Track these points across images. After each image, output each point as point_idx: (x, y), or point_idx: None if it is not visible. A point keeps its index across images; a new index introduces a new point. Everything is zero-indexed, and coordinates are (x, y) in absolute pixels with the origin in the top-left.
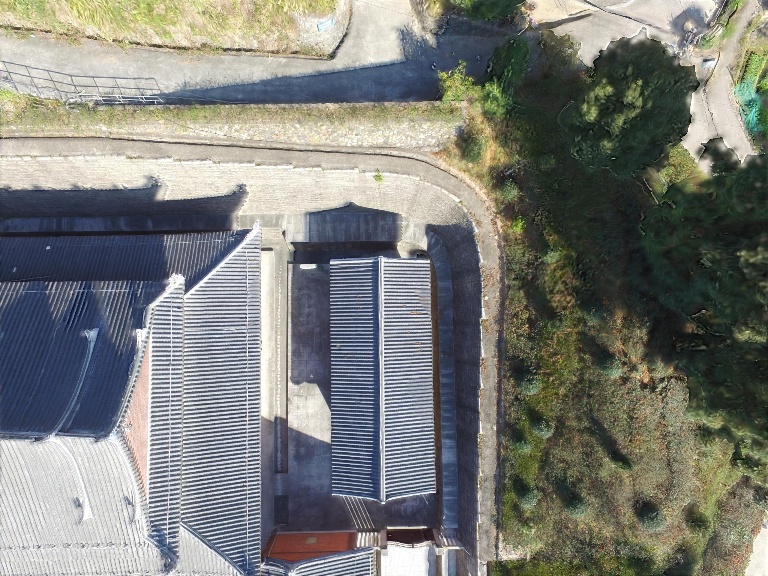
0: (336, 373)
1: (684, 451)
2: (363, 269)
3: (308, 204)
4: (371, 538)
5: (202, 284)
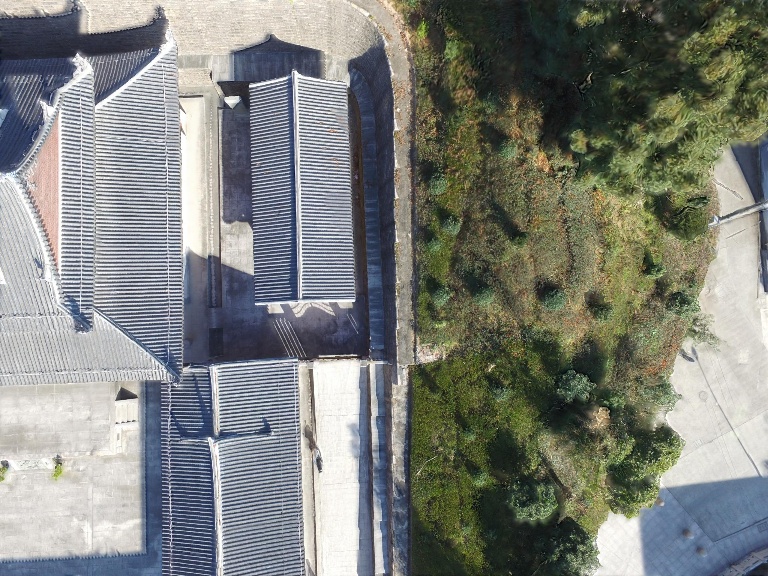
0: (256, 190)
1: (585, 237)
2: (279, 88)
3: (230, 39)
4: (301, 361)
5: (119, 94)
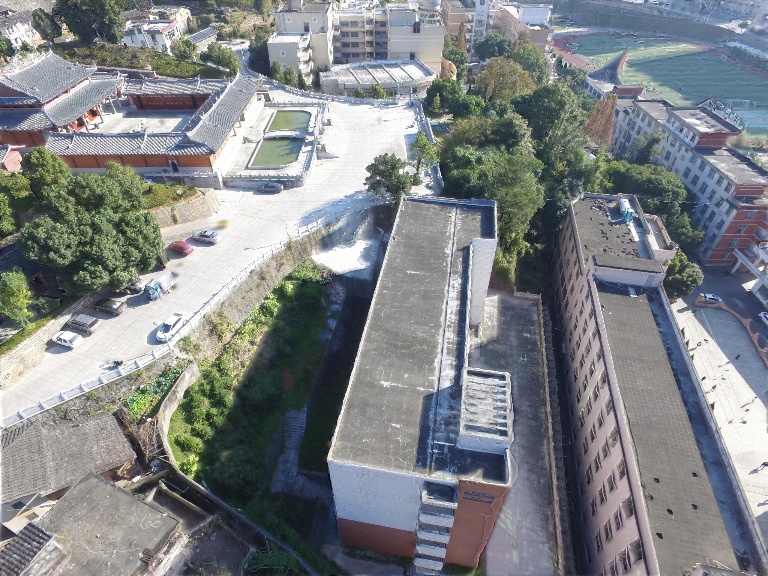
0: None
1: None
2: None
3: None
4: None
5: None
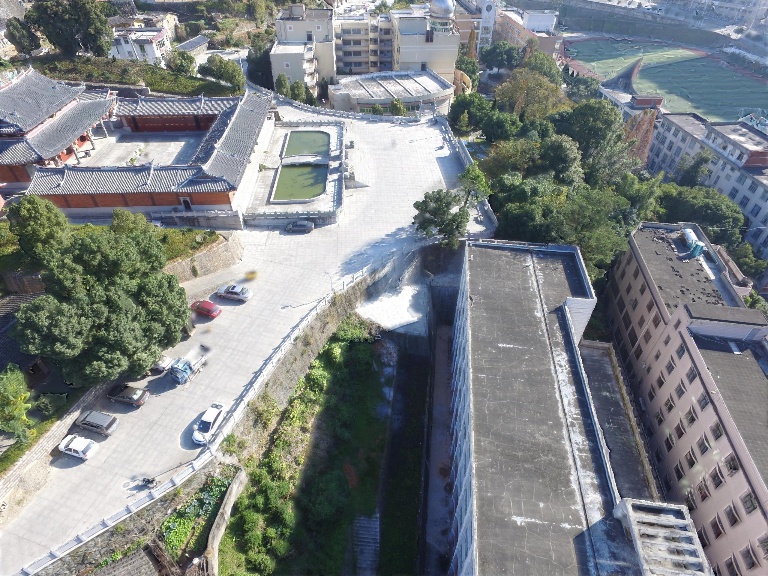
0: None
1: None
2: None
3: None
4: None
5: None
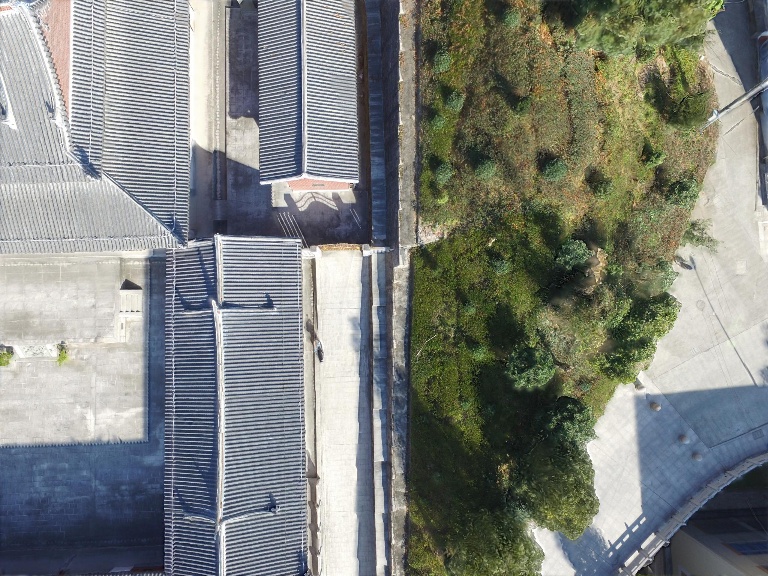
0: (263, 72)
1: (586, 111)
2: None
3: None
4: None
5: None
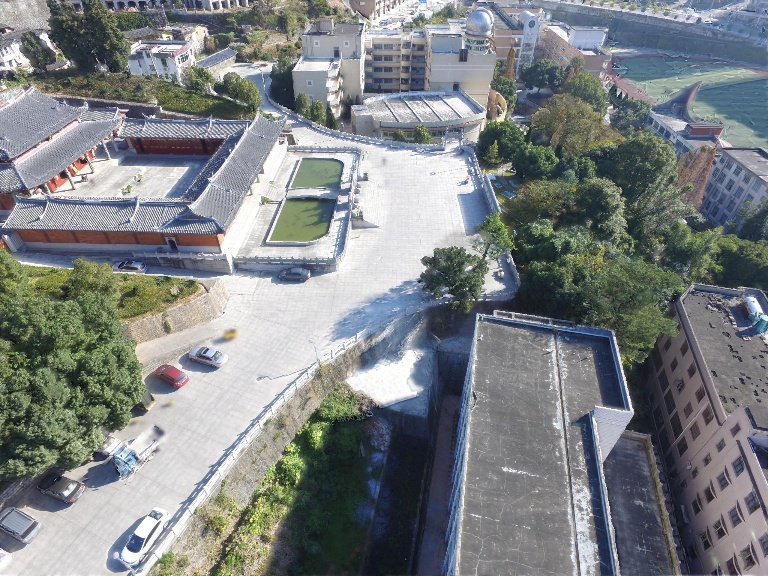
0: None
1: None
2: None
3: None
4: None
5: None
